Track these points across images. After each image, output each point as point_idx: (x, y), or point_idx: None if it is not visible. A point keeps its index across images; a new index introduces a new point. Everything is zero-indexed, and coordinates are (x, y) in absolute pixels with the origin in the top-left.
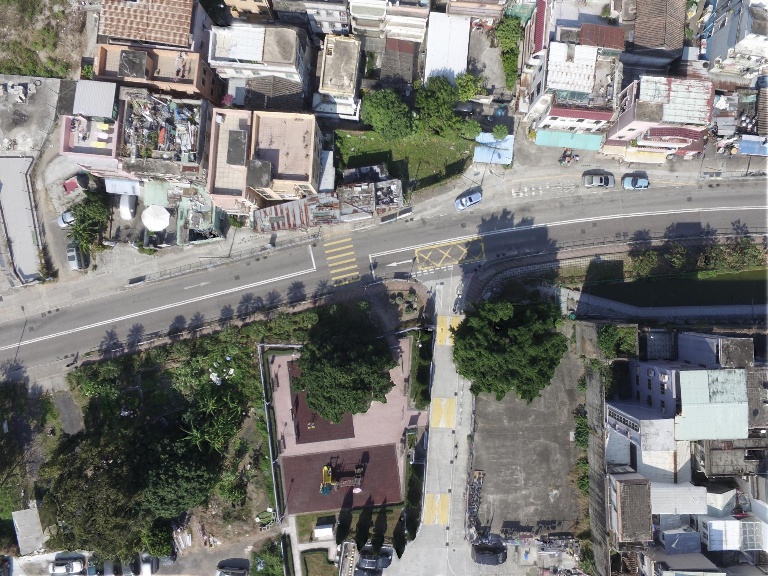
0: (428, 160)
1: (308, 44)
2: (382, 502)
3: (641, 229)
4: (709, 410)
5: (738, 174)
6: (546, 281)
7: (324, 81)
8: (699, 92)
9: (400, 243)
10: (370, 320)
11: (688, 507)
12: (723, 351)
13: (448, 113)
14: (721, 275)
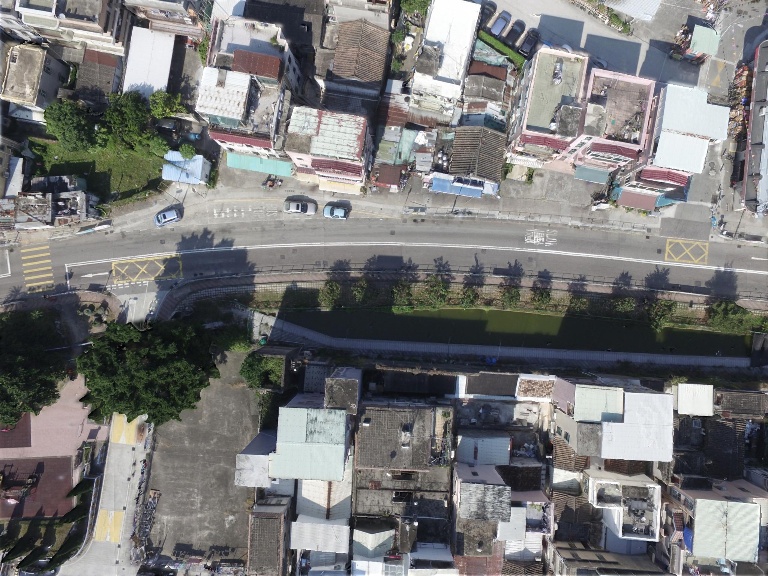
0: (131, 174)
1: (1, 49)
2: (53, 514)
3: (341, 259)
4: (305, 449)
5: (443, 211)
6: (239, 304)
7: (6, 88)
8: (351, 127)
9: (97, 255)
10: (57, 330)
11: (330, 545)
12: (327, 390)
13: (136, 129)
14: (419, 311)
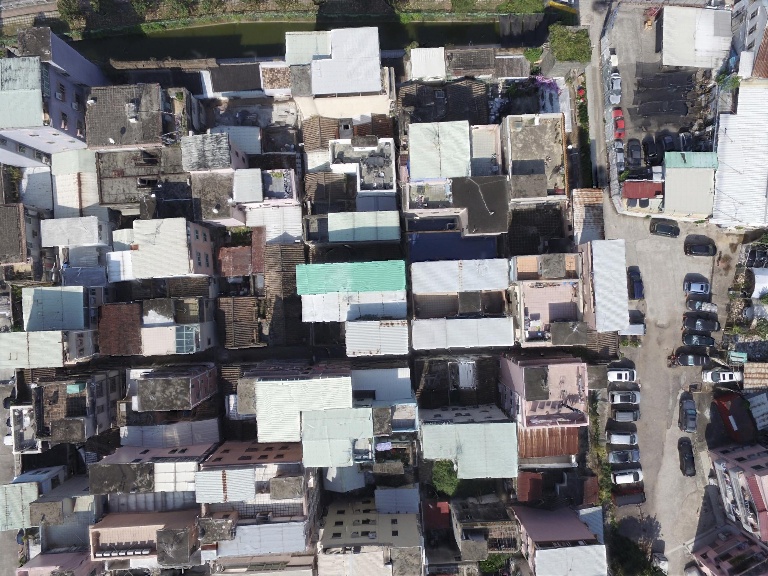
0: None
1: None
2: None
3: None
4: (2, 98)
5: None
6: None
7: None
8: None
9: None
10: None
11: (81, 237)
12: (19, 40)
13: None
14: (171, 31)
